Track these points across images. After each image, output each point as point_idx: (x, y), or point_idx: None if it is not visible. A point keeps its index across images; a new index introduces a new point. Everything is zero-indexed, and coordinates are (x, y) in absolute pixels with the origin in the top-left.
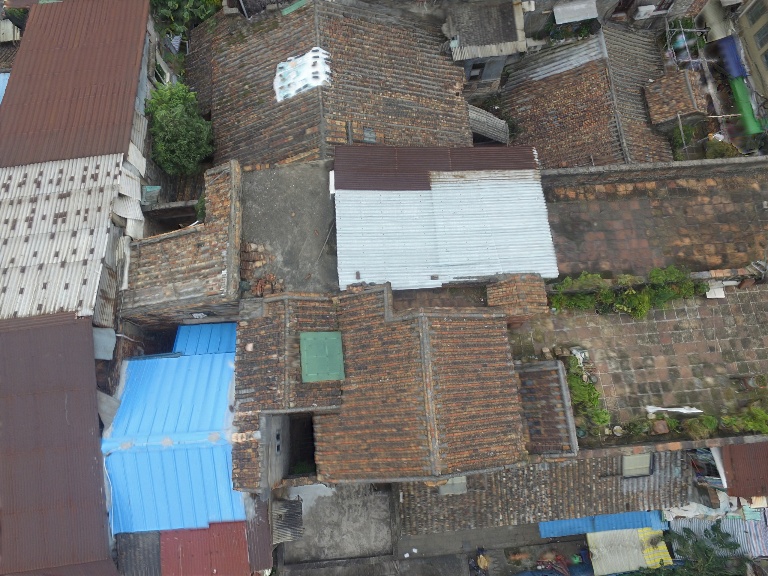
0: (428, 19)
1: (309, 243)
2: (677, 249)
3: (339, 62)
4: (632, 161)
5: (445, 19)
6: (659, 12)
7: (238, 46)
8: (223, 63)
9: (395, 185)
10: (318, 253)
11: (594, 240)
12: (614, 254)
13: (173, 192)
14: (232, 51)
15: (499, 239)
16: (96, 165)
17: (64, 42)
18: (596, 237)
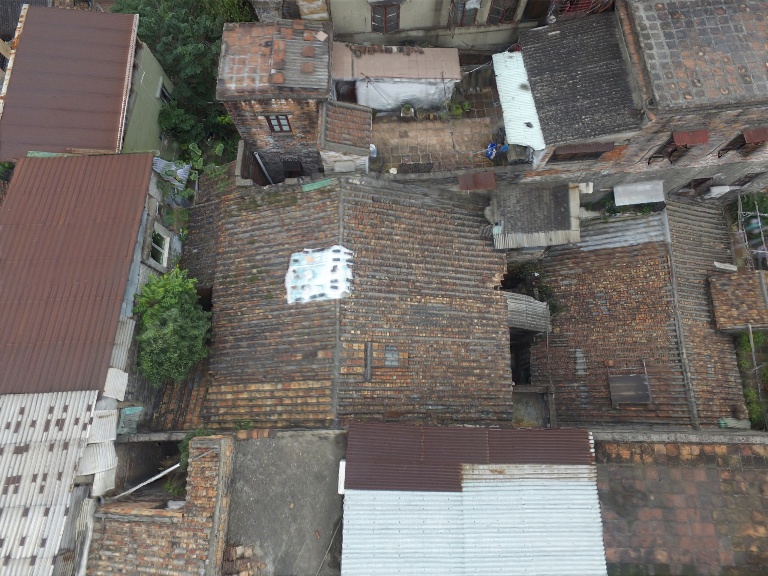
0: (469, 196)
1: (308, 549)
2: (749, 541)
3: (363, 262)
4: (692, 376)
5: (489, 201)
6: (732, 187)
7: (250, 215)
8: (231, 231)
9: (418, 483)
10: (317, 565)
11: (649, 519)
12: (673, 541)
13: (161, 385)
14: (242, 219)
15: (541, 565)
16: (64, 406)
17: (49, 216)
18: (652, 516)
